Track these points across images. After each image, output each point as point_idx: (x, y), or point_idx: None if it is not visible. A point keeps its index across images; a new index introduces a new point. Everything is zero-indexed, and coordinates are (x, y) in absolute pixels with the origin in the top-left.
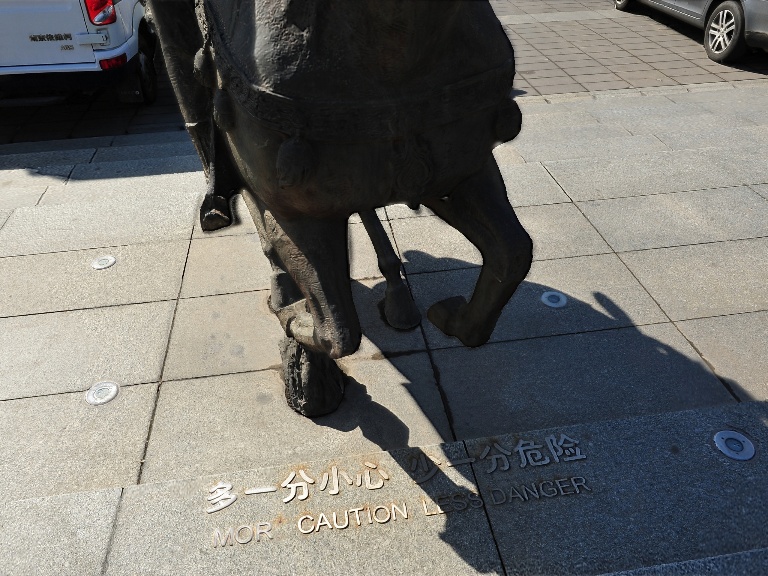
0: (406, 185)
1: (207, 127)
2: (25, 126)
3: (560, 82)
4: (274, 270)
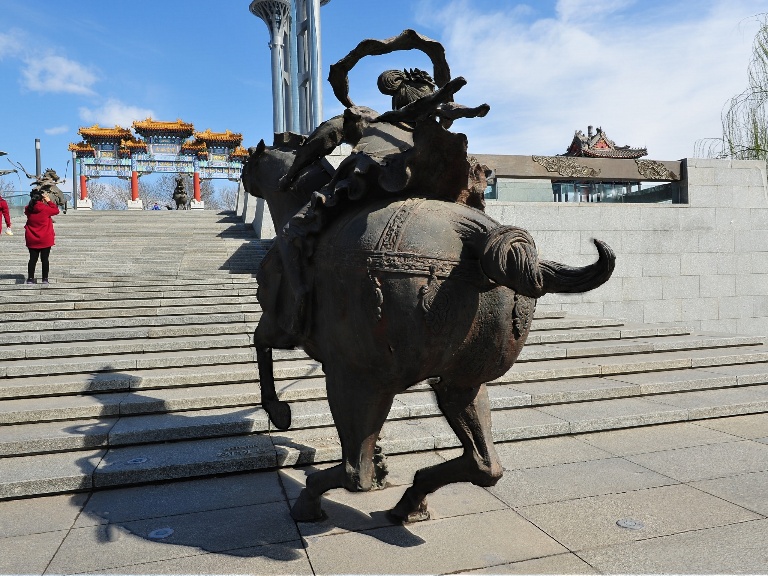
0: None
1: None
2: None
3: None
4: None
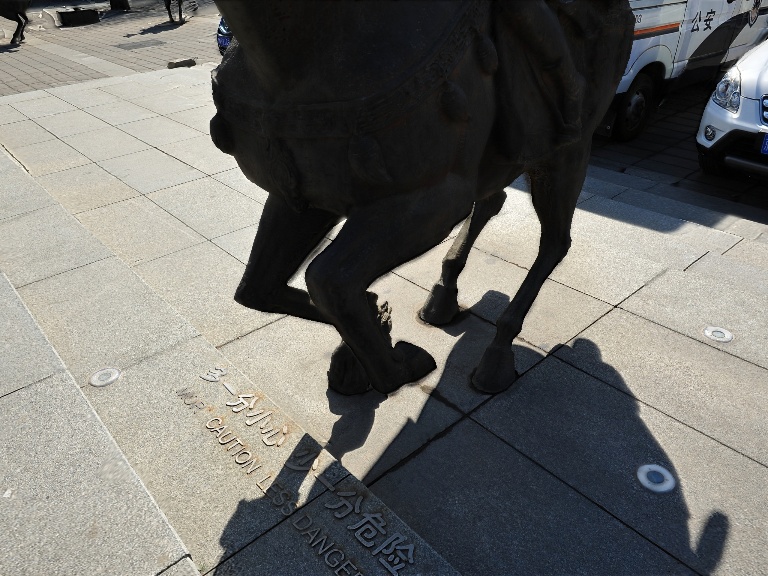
0: (278, 182)
1: None
2: None
3: None
4: (439, 279)
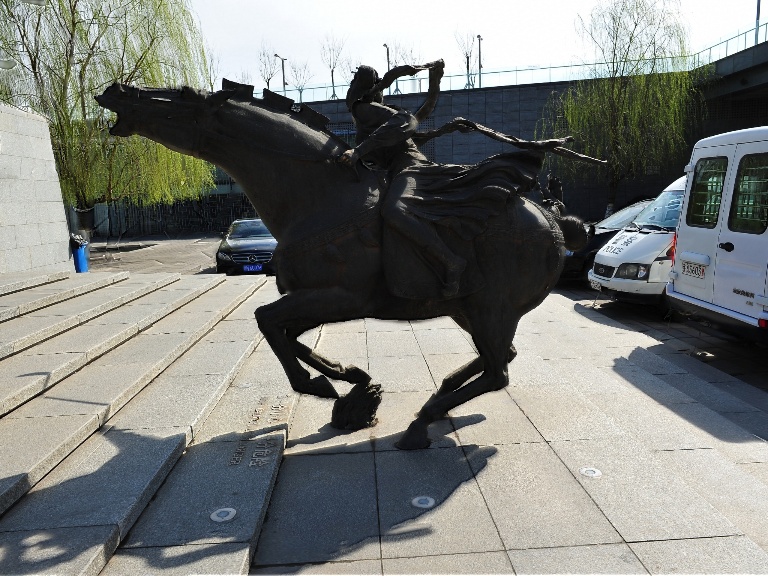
0: None
1: None
2: (742, 359)
3: None
4: None
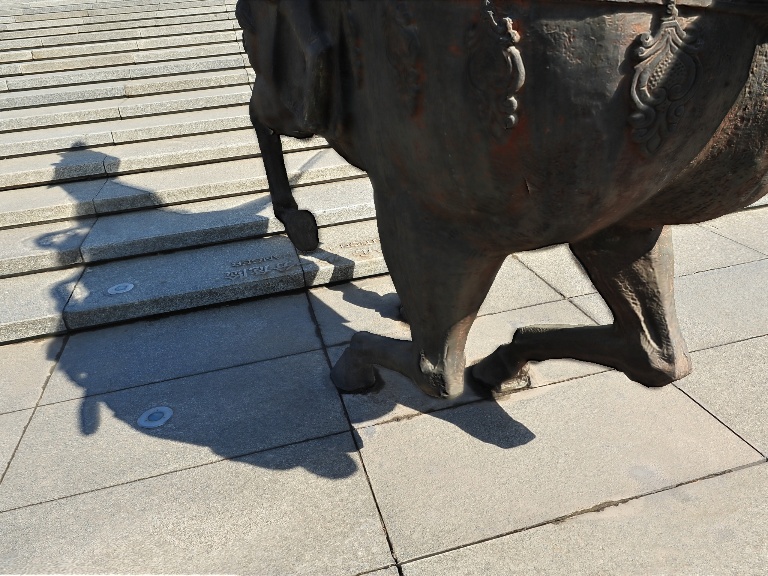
0: None
1: None
2: None
3: None
4: None
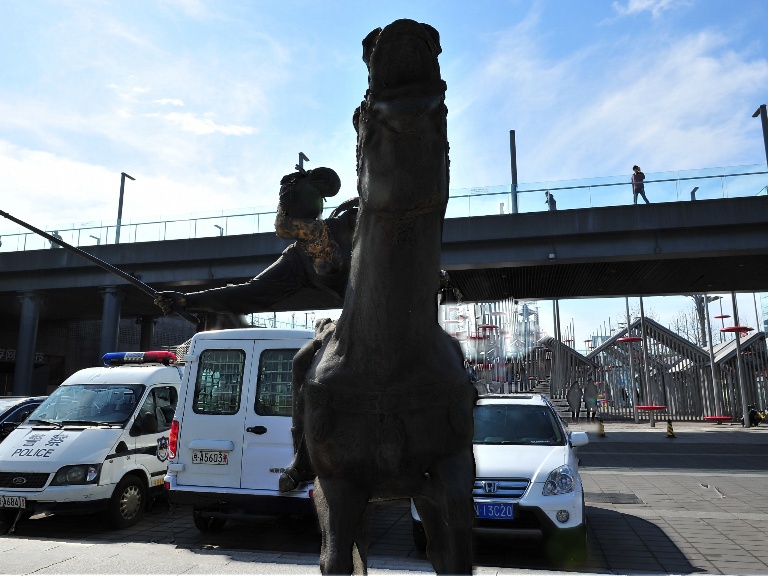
0: (386, 445)
1: (302, 430)
2: (243, 542)
3: (750, 567)
4: None
